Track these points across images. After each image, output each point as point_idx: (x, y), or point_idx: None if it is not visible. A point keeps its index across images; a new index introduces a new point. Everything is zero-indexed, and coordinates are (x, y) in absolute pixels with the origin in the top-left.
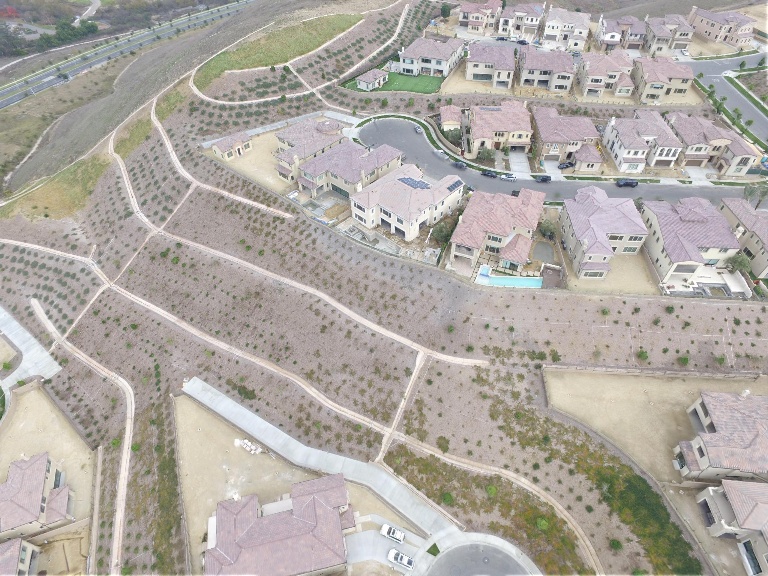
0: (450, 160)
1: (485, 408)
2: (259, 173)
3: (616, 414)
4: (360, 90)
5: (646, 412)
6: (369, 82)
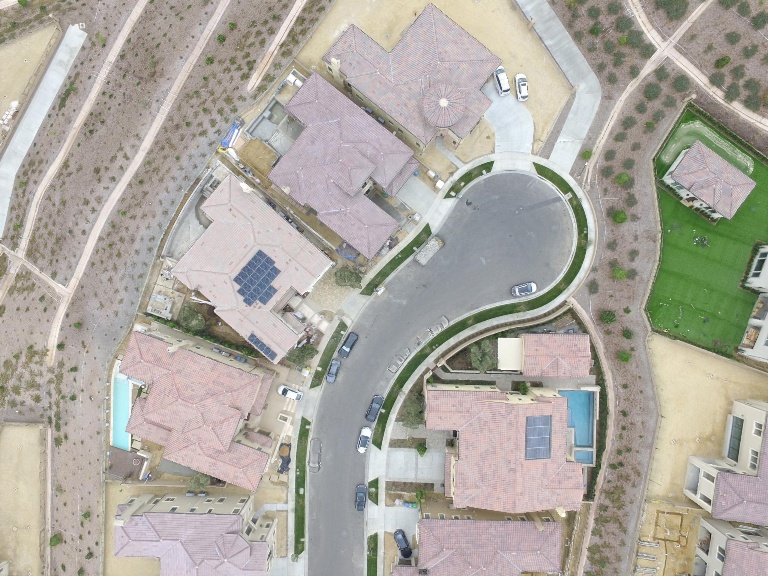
0: (421, 345)
1: (11, 356)
2: (361, 7)
3: (0, 489)
4: (669, 157)
5: (4, 520)
6: (674, 174)
